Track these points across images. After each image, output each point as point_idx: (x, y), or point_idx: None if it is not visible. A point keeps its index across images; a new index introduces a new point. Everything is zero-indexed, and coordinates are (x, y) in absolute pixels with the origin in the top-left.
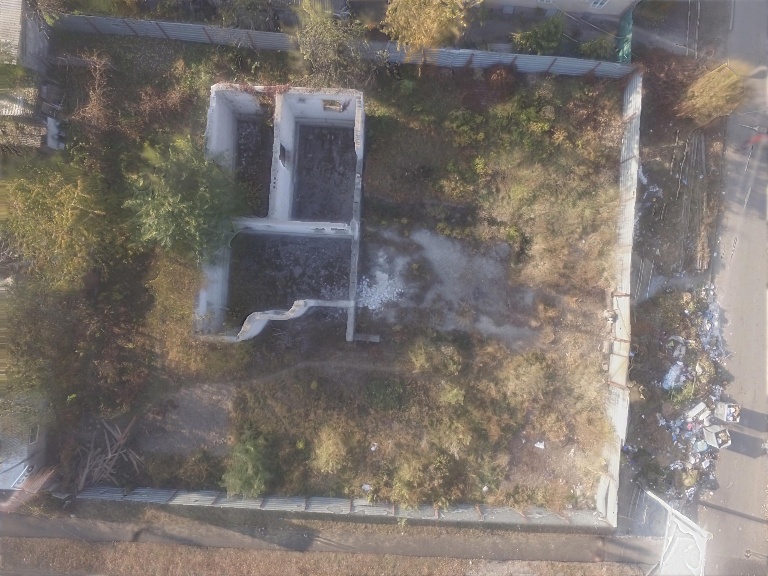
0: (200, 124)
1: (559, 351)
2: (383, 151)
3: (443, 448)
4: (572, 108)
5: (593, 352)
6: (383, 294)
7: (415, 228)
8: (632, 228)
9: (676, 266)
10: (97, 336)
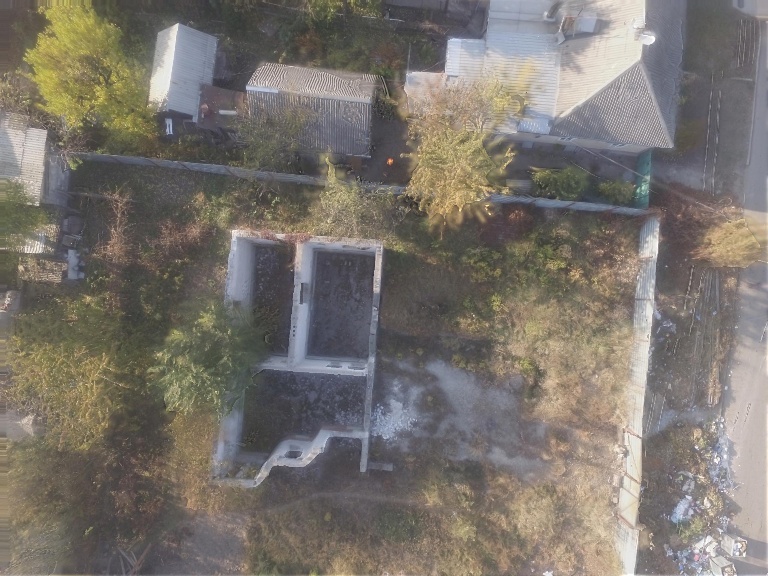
0: (219, 256)
1: (570, 483)
2: (400, 285)
3: None
4: (589, 245)
5: (603, 484)
6: (397, 423)
7: (430, 358)
8: (646, 372)
9: (687, 401)
10: (114, 466)
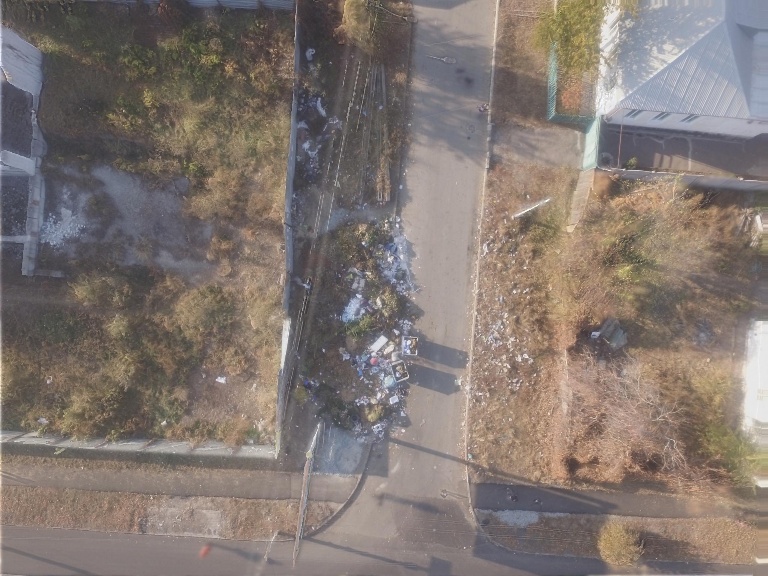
0: None
1: (237, 285)
2: (57, 87)
3: (116, 381)
4: (245, 41)
5: (272, 285)
6: (66, 230)
7: (97, 164)
8: (288, 156)
9: (355, 198)
10: None
